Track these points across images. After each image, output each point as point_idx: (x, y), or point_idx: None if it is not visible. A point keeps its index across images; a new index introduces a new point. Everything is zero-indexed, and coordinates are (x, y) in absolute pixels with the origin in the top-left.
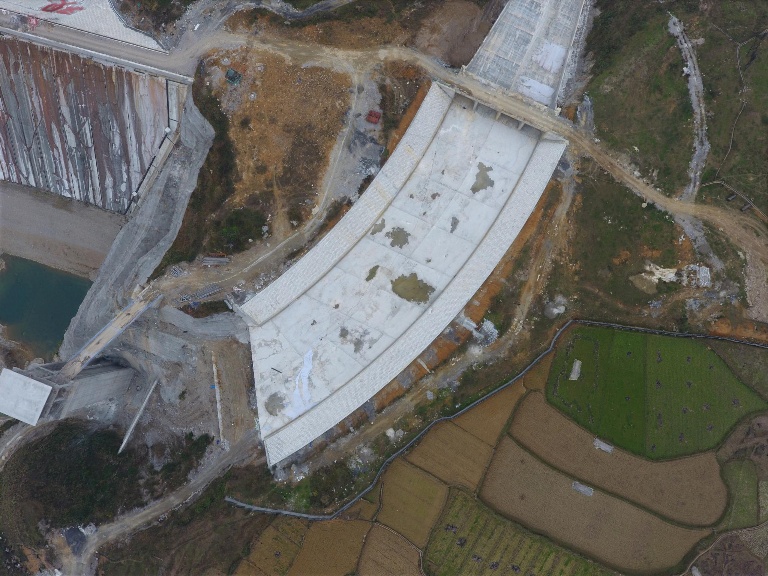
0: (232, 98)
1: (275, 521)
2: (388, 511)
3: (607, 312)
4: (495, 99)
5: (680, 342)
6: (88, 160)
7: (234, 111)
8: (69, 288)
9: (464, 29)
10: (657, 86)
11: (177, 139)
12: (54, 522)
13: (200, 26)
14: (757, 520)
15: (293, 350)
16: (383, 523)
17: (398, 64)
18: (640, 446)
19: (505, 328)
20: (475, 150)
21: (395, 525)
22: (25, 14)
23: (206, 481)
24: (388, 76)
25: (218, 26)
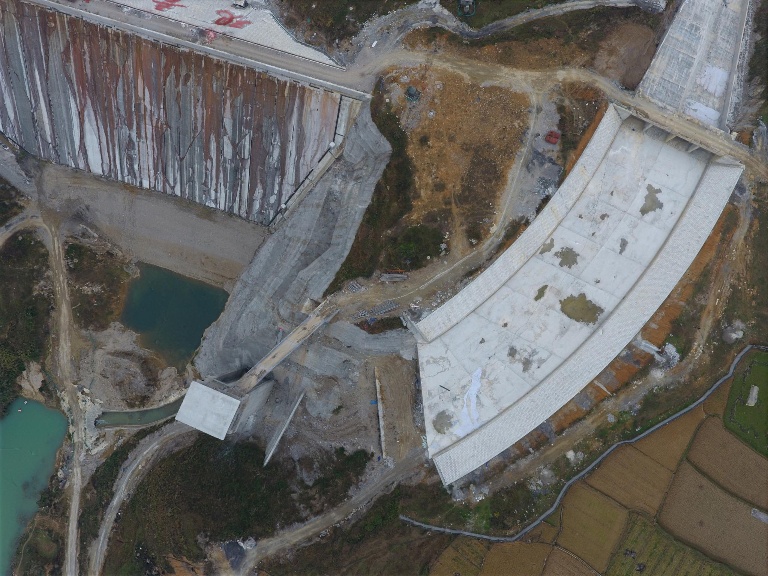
0: (411, 115)
1: (455, 542)
2: (568, 534)
3: None
4: (672, 122)
5: None
6: (241, 172)
7: (413, 128)
8: (201, 297)
9: (640, 52)
10: None
11: (340, 153)
12: (213, 535)
13: (378, 43)
14: None
15: (461, 368)
16: (563, 546)
17: (577, 85)
18: None
19: (686, 352)
20: (644, 172)
21: (575, 549)
22: (204, 27)
23: (368, 498)
24: (567, 97)
25: (396, 44)
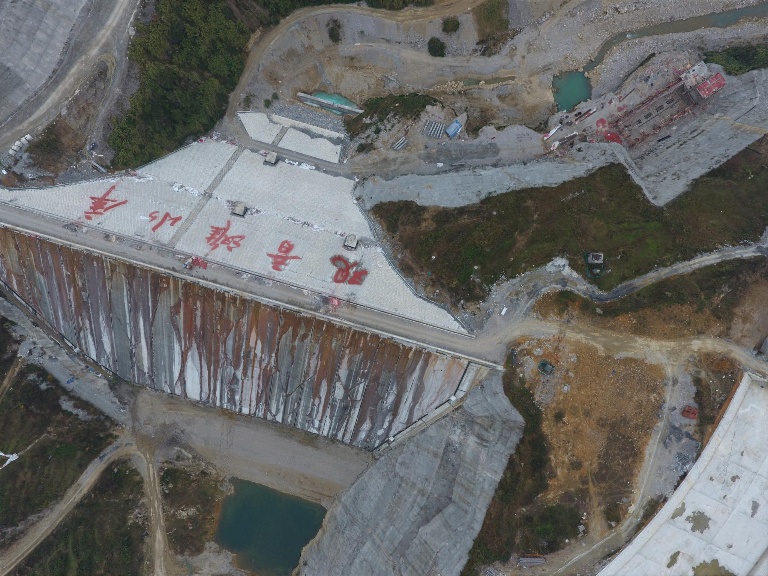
0: (545, 390)
1: None
2: None
3: None
4: None
5: None
6: (350, 409)
7: (547, 404)
8: (297, 511)
9: None
10: None
11: (460, 405)
12: None
13: (508, 311)
14: None
15: None
16: None
17: (712, 356)
18: None
19: None
20: None
21: None
22: (327, 294)
23: None
24: (703, 369)
25: (526, 311)
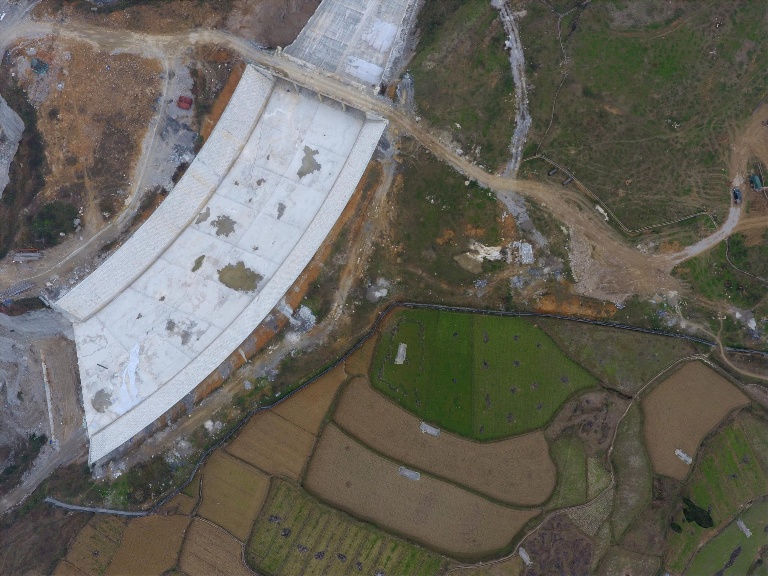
0: (39, 89)
1: (92, 520)
2: (209, 505)
3: (432, 293)
4: (312, 80)
5: (507, 321)
6: None
7: (41, 102)
8: None
9: (279, 9)
10: (480, 61)
11: (1, 134)
12: None
13: (6, 15)
14: (586, 498)
15: (119, 345)
16: (204, 517)
17: (209, 47)
18: (468, 428)
19: (323, 314)
20: (300, 133)
21: (216, 518)
22: None
23: (38, 482)
24: (199, 60)
25: (24, 15)
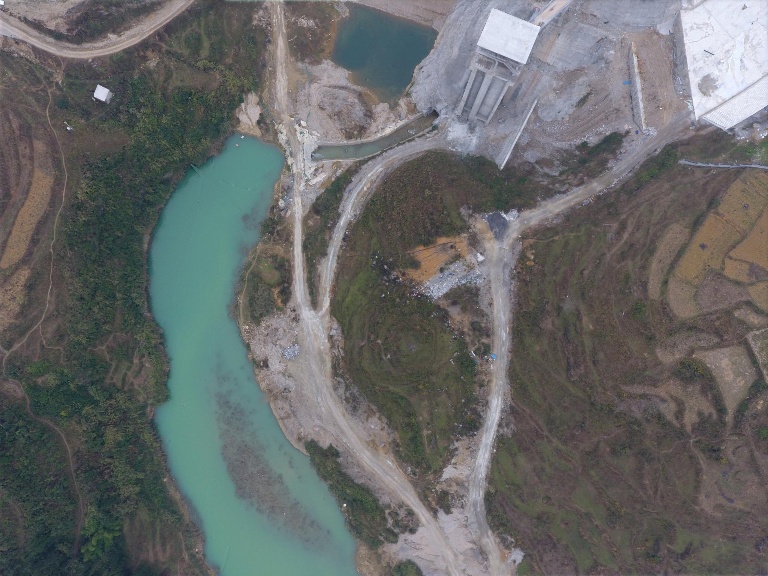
0: None
1: (743, 174)
2: None
3: None
4: None
5: None
6: None
7: None
8: (408, 39)
9: None
10: None
11: None
12: (476, 207)
13: None
14: None
15: (725, 33)
16: None
17: None
18: None
19: None
20: None
21: None
22: None
23: (630, 167)
24: None
25: None
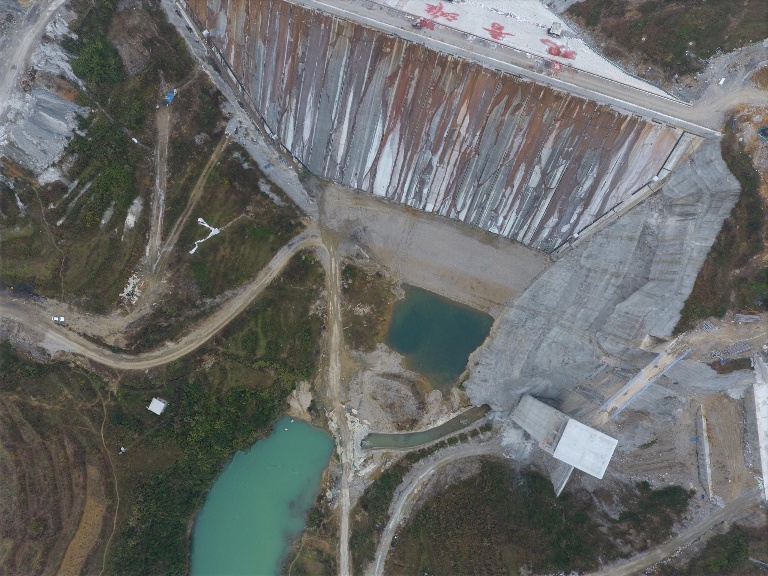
0: (764, 155)
1: None
2: None
3: None
4: None
5: None
6: (541, 200)
7: (766, 168)
8: (463, 321)
9: None
10: None
11: None
12: (537, 568)
13: (727, 81)
14: None
15: None
16: None
17: None
18: None
19: None
20: None
21: None
22: (549, 59)
23: (695, 536)
24: None
25: (744, 82)
